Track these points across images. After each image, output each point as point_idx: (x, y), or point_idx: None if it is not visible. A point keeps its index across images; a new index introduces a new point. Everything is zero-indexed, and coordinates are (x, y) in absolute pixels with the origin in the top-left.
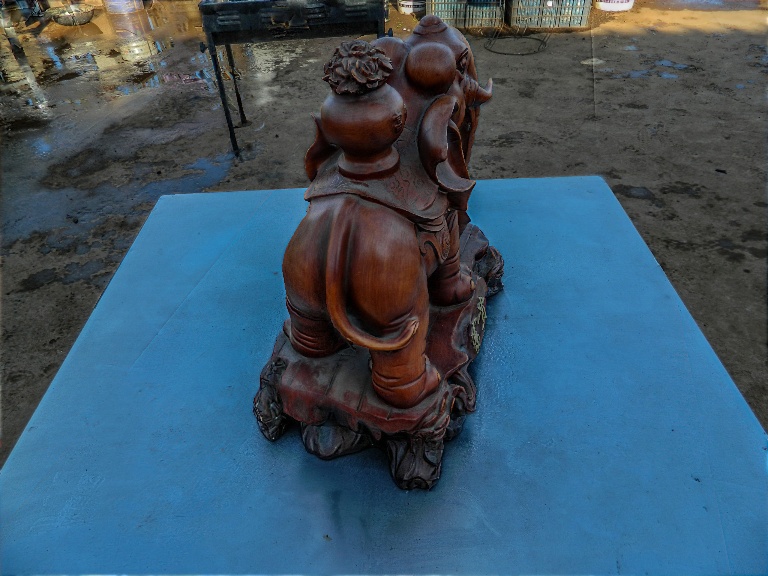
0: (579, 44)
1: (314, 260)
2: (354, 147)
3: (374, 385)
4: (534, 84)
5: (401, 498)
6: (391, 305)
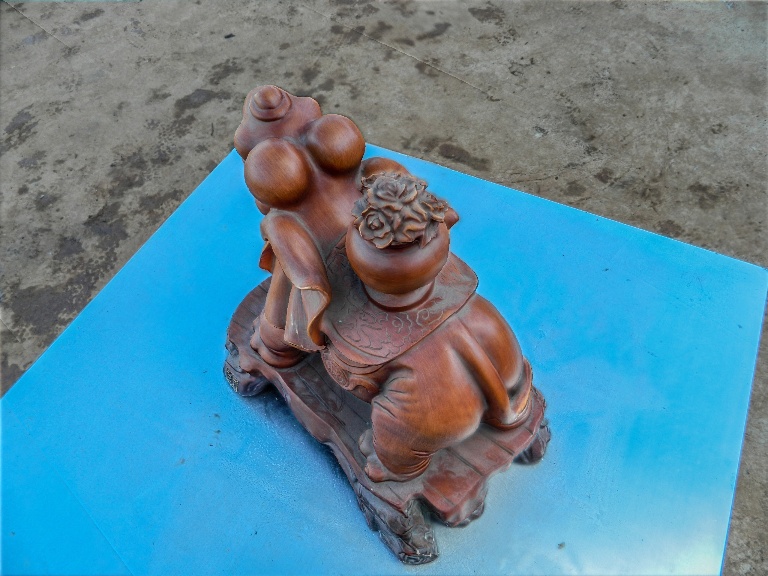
0: None
1: (473, 399)
2: None
3: (508, 427)
4: None
5: (546, 467)
6: (522, 363)
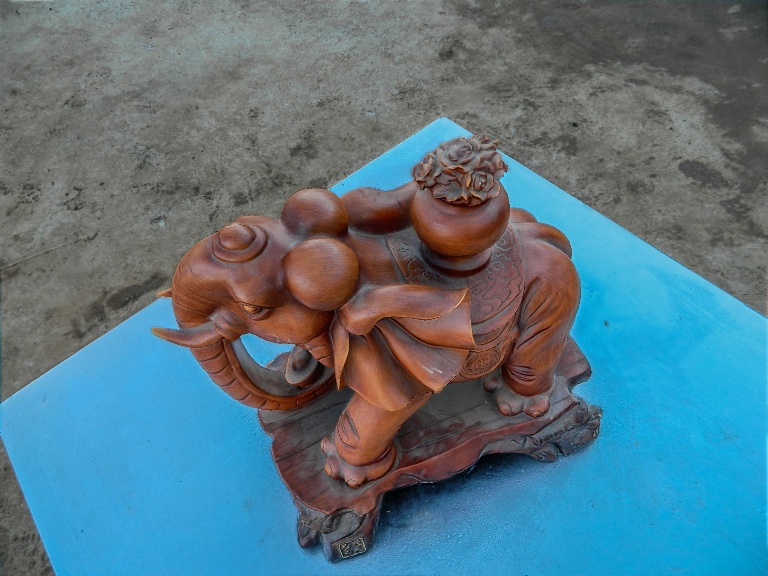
0: None
1: None
2: None
3: None
4: None
5: None
6: None
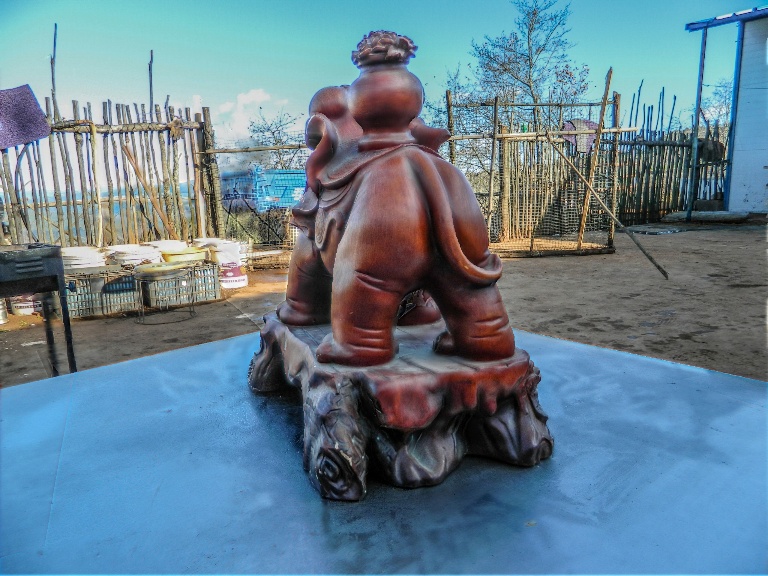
0: (224, 308)
1: (414, 193)
2: (400, 108)
3: (476, 340)
4: (207, 336)
5: (541, 471)
6: (484, 230)
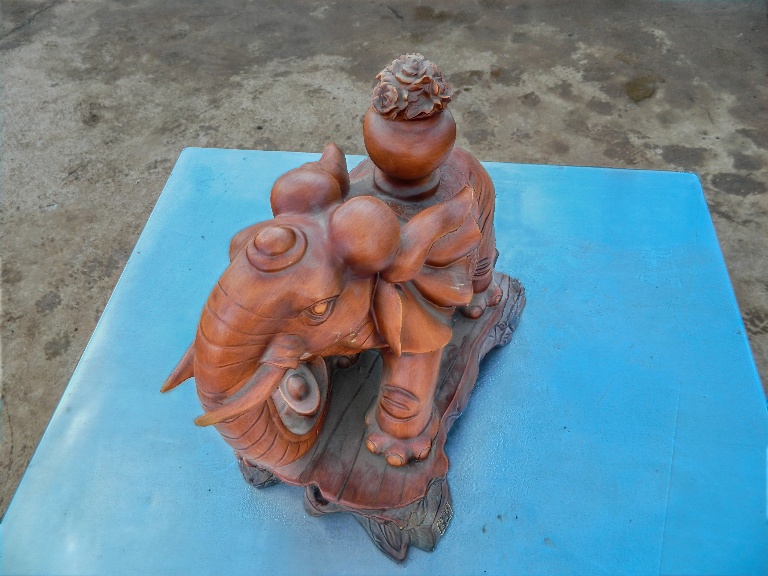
0: None
1: None
2: None
3: None
4: None
5: None
6: None
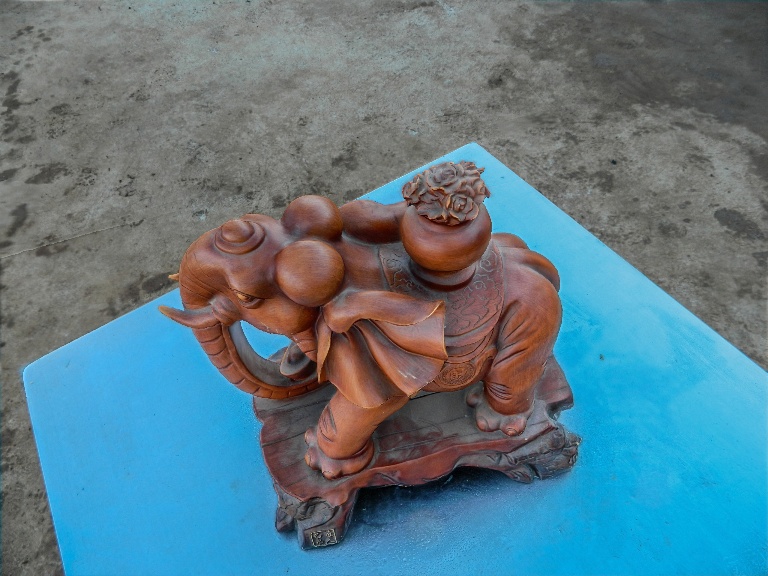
0: None
1: None
2: None
3: None
4: None
5: None
6: None
